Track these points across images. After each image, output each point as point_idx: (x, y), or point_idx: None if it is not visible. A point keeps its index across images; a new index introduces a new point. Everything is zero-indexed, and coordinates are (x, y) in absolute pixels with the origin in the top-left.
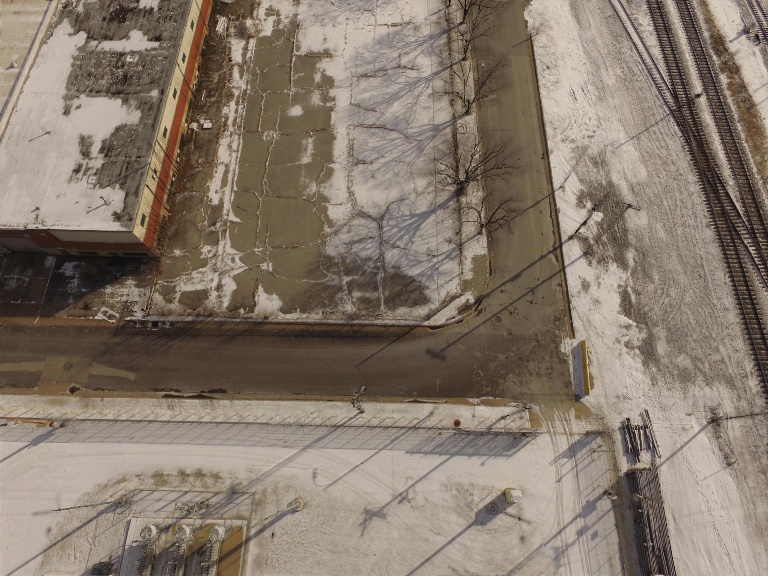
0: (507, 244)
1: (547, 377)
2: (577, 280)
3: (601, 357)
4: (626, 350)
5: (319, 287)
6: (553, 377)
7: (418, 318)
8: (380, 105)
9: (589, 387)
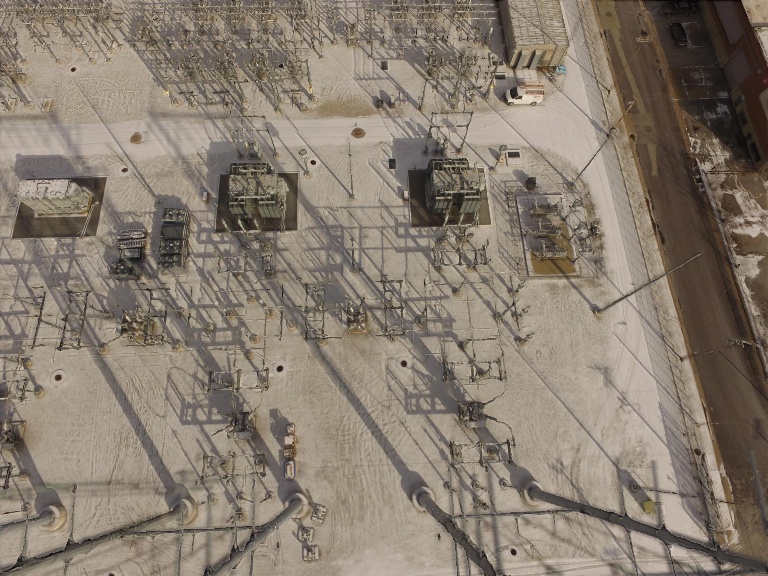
0: None
1: None
2: None
3: None
4: None
5: None
6: None
7: None
8: None
9: None
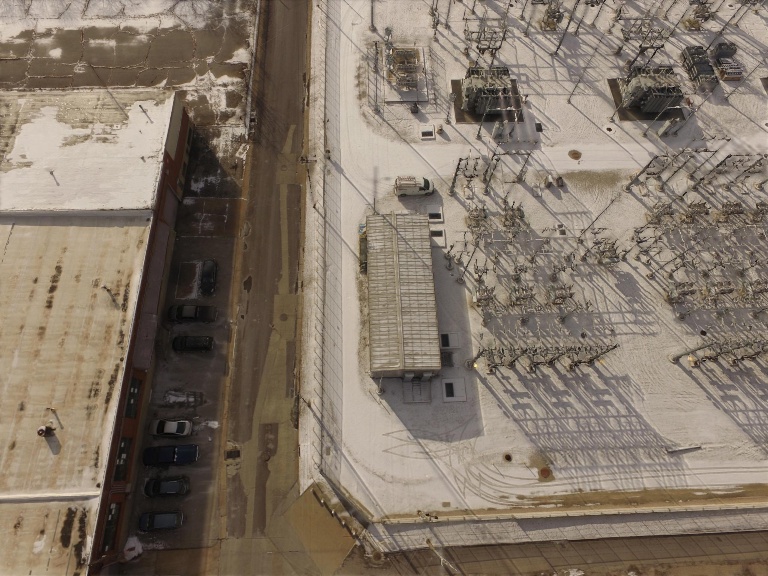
0: None
1: None
2: None
3: None
4: None
5: (230, 29)
6: None
7: None
8: (64, 1)
9: None
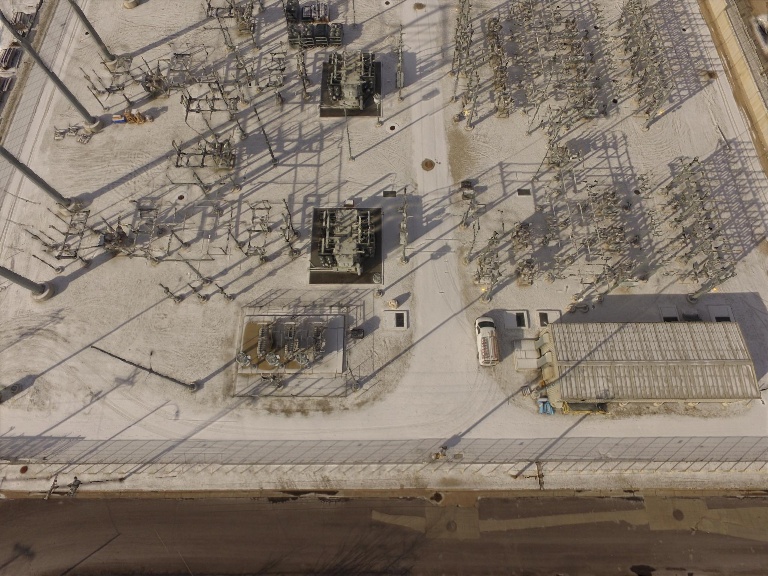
0: None
1: None
2: None
3: None
4: None
5: None
6: None
7: None
8: None
9: None
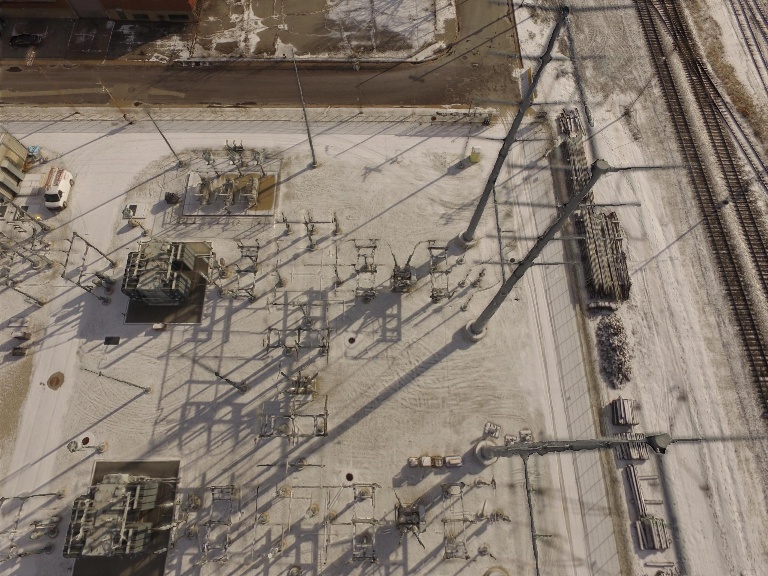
0: (471, 11)
1: (502, 91)
2: (525, 32)
3: (543, 79)
4: (562, 74)
5: (325, 39)
6: (506, 91)
7: (403, 57)
8: None
9: (533, 95)
